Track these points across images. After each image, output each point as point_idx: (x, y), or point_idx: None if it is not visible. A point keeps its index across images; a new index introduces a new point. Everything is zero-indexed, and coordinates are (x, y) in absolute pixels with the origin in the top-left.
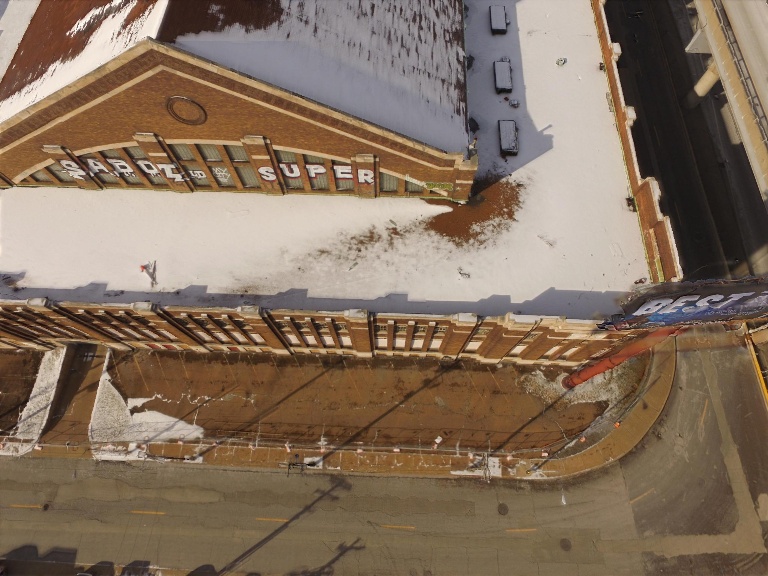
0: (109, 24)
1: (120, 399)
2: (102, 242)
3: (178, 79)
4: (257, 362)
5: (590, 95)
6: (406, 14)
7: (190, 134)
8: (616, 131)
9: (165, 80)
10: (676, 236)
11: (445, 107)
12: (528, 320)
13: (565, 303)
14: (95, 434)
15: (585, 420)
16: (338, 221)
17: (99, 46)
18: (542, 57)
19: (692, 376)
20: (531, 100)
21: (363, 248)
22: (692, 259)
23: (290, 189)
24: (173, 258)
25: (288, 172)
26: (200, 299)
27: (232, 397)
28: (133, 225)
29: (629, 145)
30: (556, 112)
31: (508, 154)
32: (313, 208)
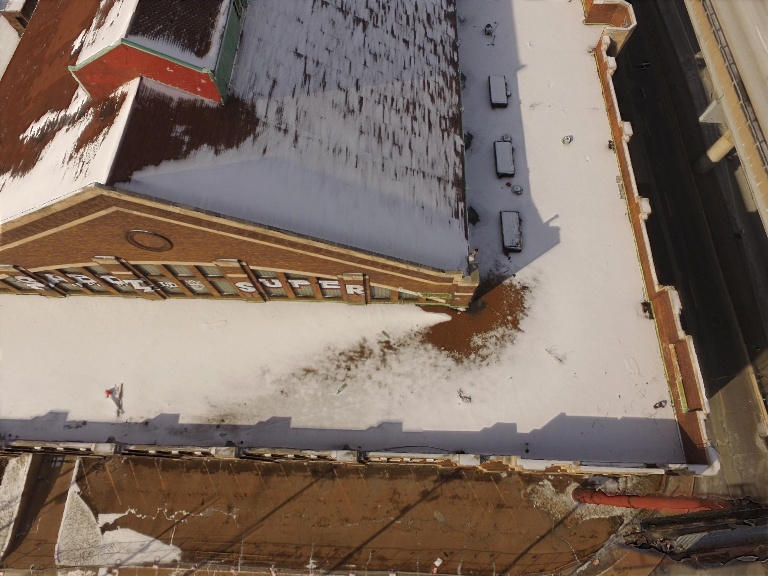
0: (62, 140)
1: (90, 515)
2: (63, 361)
3: (136, 217)
4: (240, 471)
5: (599, 179)
6: (398, 104)
7: (156, 257)
8: (628, 222)
9: (121, 218)
10: (691, 319)
11: (442, 211)
12: (538, 466)
13: (577, 432)
14: (62, 557)
15: (598, 539)
16: (325, 333)
17: (49, 168)
18: (546, 134)
19: (713, 485)
20: (535, 185)
21: (353, 366)
22: (709, 346)
23: (272, 296)
24: (142, 380)
25: (269, 284)
26: (171, 431)
27: (212, 512)
28: (98, 340)
29: (644, 242)
30: (563, 199)
31: (511, 251)
32: (298, 317)
